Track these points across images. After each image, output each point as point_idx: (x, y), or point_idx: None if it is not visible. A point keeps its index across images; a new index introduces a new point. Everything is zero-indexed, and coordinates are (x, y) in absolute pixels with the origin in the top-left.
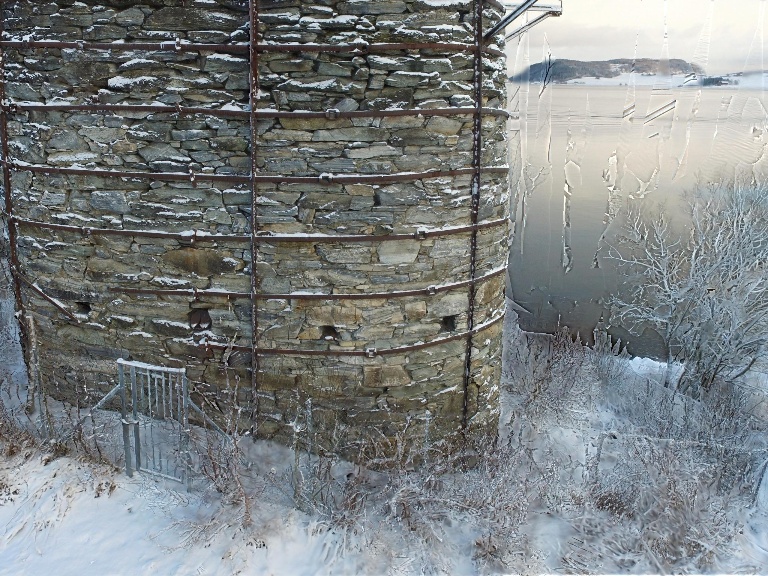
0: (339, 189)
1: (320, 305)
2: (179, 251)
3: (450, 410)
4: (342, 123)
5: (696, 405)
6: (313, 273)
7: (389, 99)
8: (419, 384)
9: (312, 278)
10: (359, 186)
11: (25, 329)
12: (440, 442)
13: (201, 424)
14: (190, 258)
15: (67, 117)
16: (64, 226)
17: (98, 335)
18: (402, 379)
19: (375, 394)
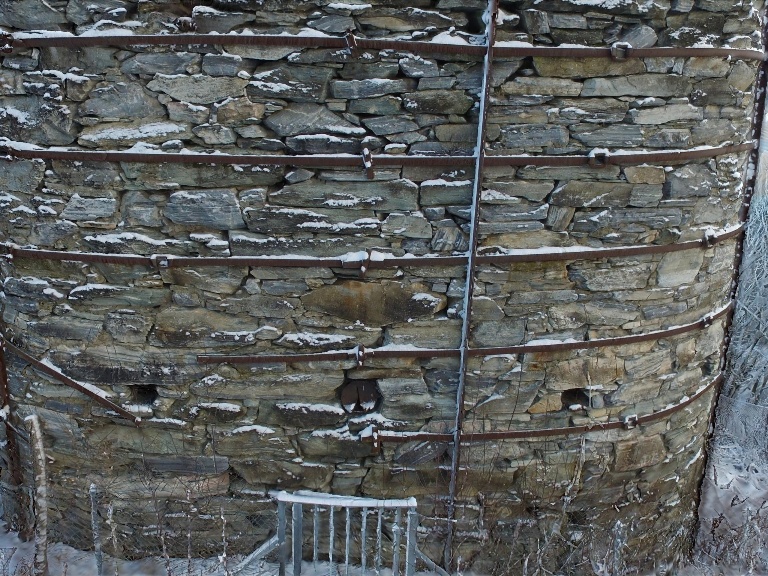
0: (615, 174)
1: (568, 358)
2: (334, 287)
3: (693, 484)
4: (631, 66)
5: None
6: (562, 309)
7: (697, 30)
8: (676, 457)
9: (561, 317)
10: (645, 168)
11: (13, 436)
12: (680, 530)
13: (348, 559)
14: (353, 298)
15: (123, 58)
16: (112, 255)
17: (170, 437)
18: (661, 454)
19: (626, 481)
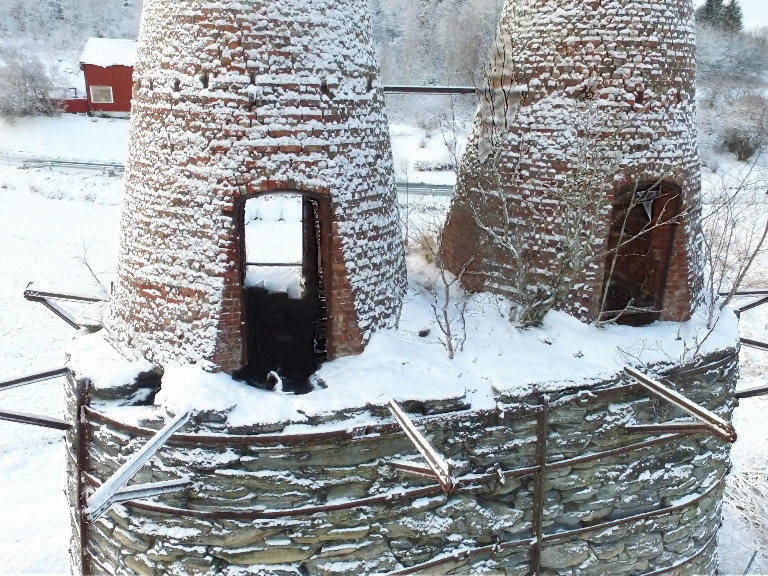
0: None
1: None
2: None
3: None
4: None
5: None
6: None
7: None
8: None
9: None
10: None
11: None
12: None
13: None
14: None
15: None
16: None
17: None
18: None
19: None
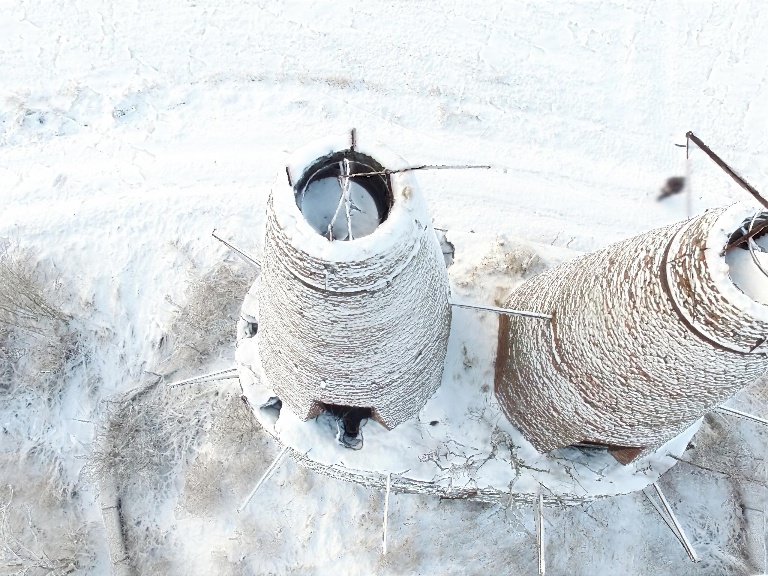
0: None
1: None
2: None
3: None
4: None
5: (105, 492)
6: None
7: None
8: None
9: None
10: None
11: None
12: None
13: None
14: None
15: None
16: None
17: None
18: None
19: None
